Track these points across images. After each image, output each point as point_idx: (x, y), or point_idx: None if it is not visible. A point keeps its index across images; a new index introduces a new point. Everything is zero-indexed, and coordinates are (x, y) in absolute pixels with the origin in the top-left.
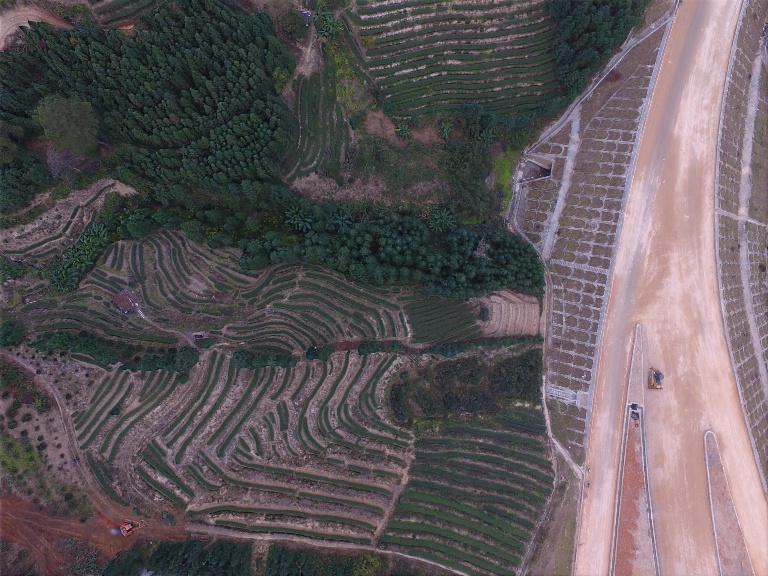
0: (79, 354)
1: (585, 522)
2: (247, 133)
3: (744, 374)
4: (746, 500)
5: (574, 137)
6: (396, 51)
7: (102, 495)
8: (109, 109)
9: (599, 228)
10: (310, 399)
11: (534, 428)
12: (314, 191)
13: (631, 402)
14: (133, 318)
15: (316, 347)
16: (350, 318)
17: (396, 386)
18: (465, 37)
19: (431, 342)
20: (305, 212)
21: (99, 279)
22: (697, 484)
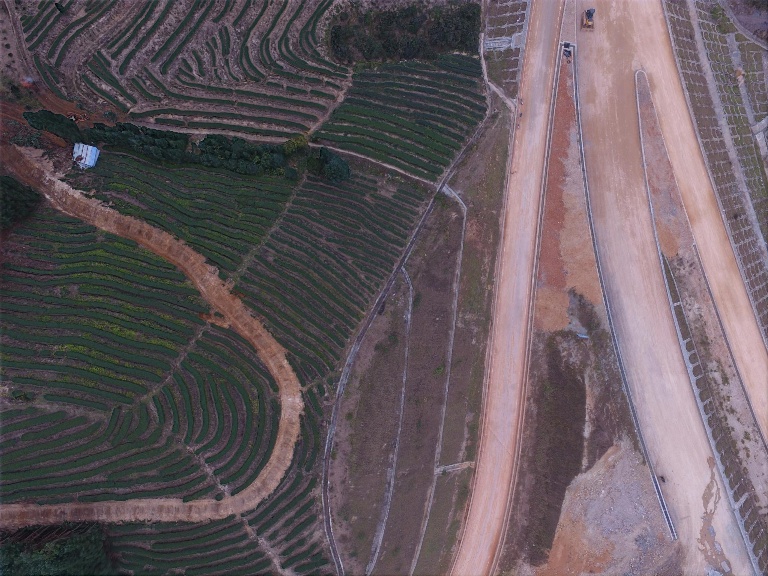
0: None
1: (517, 152)
2: None
3: (677, 27)
4: (676, 137)
5: None
6: None
7: (47, 92)
8: None
9: None
10: (251, 28)
11: (470, 72)
12: None
13: (564, 41)
14: None
15: None
16: None
17: (336, 25)
18: None
19: None
20: None
21: None
22: (628, 120)
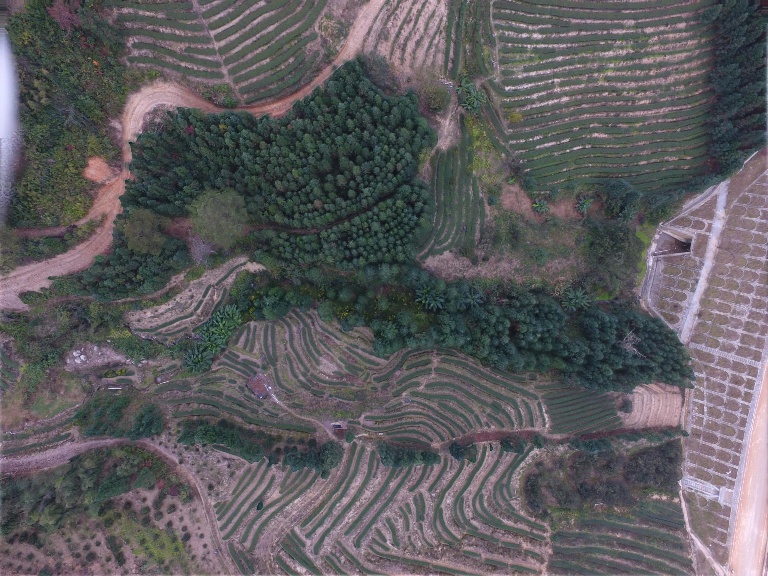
0: (220, 444)
1: None
2: (391, 218)
3: None
4: None
5: (719, 212)
6: (540, 124)
7: None
8: (251, 194)
9: (749, 316)
10: (446, 490)
11: (672, 523)
12: (446, 269)
13: None
14: (268, 403)
15: (454, 438)
16: (488, 407)
17: (532, 477)
18: (615, 110)
19: (569, 433)
20: (438, 292)
21: (232, 361)
22: None
